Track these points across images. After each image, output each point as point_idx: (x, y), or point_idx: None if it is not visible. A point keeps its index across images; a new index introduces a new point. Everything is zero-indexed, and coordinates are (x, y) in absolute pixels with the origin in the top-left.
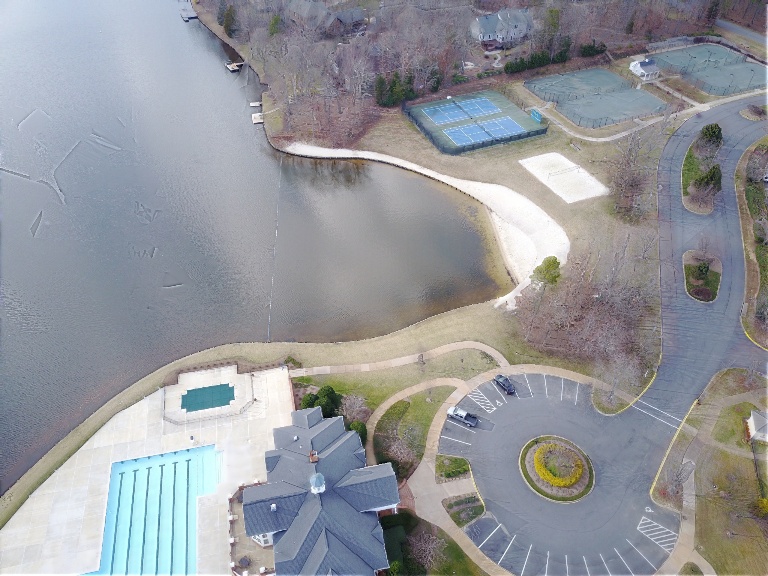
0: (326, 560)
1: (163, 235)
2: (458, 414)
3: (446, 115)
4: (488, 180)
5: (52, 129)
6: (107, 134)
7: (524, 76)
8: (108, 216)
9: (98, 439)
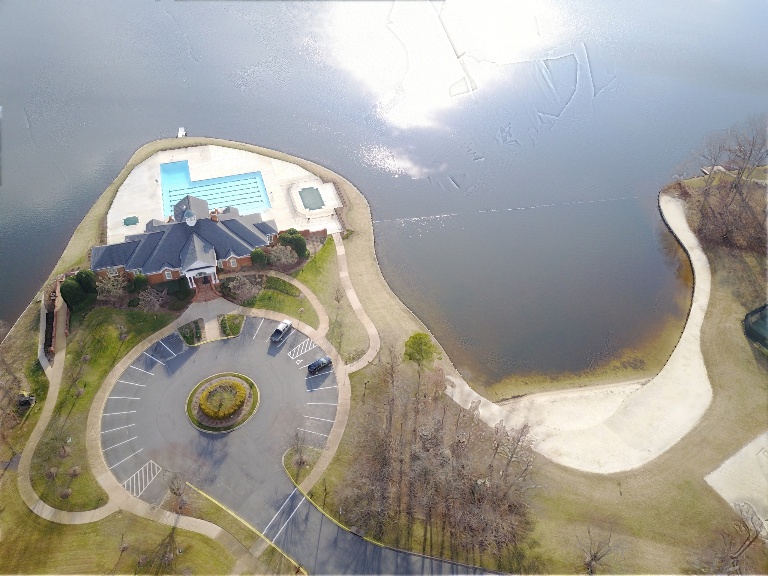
0: (145, 235)
1: (497, 156)
2: (280, 324)
3: None
4: (717, 380)
5: (585, 66)
6: (556, 72)
7: None
8: (483, 114)
9: (278, 162)
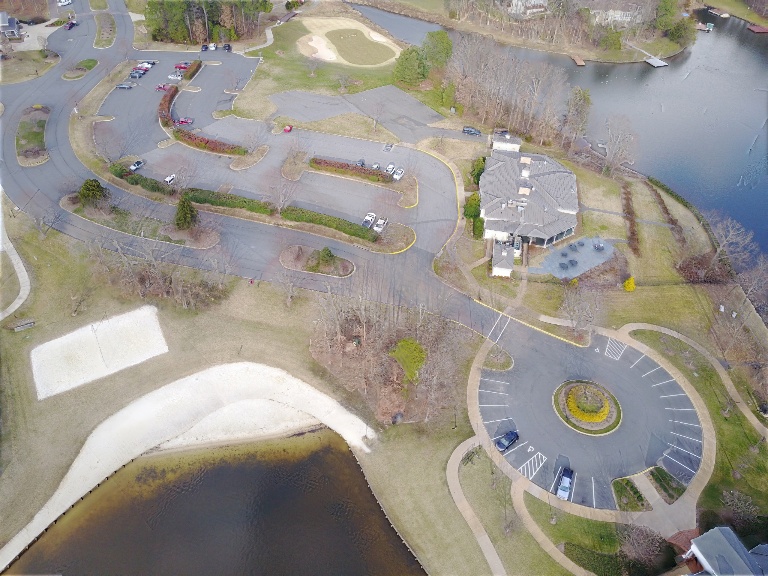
0: None
1: None
2: None
3: None
4: (74, 447)
5: None
6: None
7: None
8: None
9: None
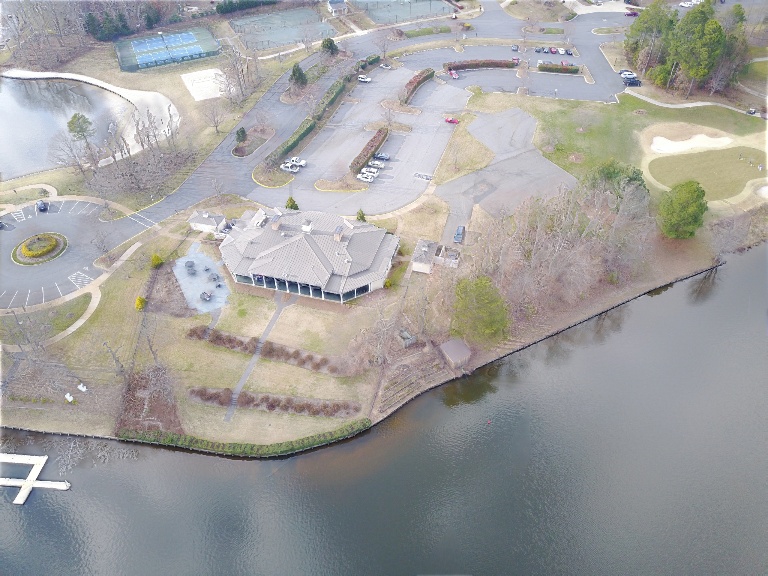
0: None
1: None
2: None
3: (148, 45)
4: (149, 89)
5: None
6: None
7: (235, 16)
8: None
9: None
